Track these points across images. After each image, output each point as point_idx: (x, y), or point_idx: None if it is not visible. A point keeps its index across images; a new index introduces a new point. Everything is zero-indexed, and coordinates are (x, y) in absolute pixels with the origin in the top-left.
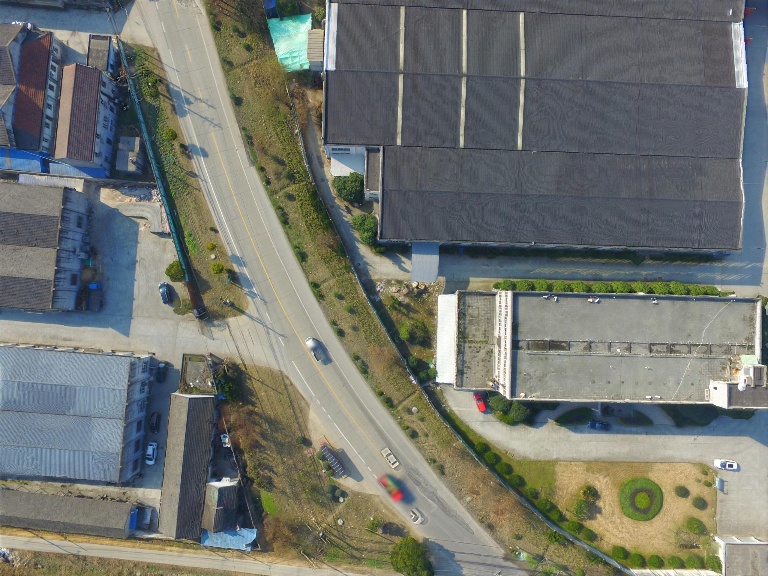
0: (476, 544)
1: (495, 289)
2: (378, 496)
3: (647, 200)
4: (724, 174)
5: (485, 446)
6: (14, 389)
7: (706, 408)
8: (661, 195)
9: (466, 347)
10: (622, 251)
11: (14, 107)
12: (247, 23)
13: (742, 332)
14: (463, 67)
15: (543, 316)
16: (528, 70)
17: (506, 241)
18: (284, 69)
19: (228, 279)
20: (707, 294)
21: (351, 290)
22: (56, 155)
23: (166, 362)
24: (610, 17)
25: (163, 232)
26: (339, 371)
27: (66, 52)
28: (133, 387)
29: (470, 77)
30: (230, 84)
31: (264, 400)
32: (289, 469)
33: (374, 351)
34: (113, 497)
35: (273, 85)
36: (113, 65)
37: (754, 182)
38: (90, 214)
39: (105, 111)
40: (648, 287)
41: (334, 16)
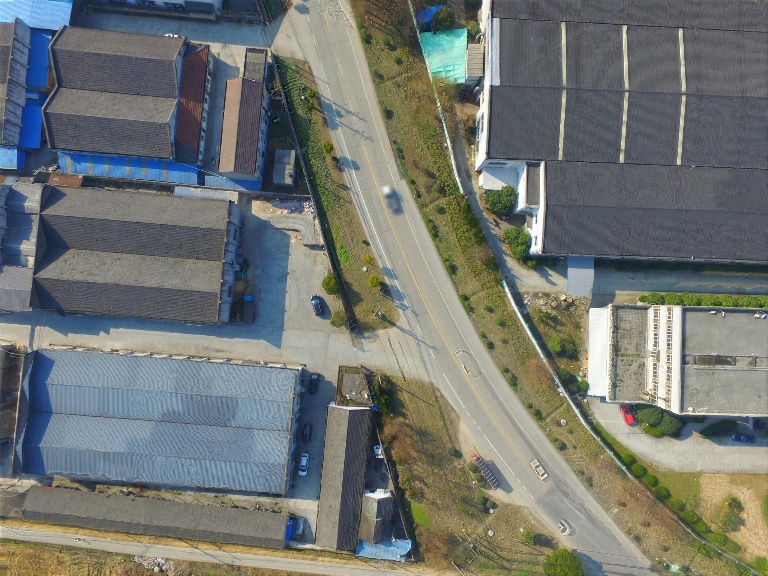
0: (623, 555)
1: (640, 302)
2: (527, 507)
3: None
4: None
5: (631, 458)
6: (172, 400)
7: None
8: None
9: (618, 360)
10: (767, 265)
11: (176, 120)
12: (398, 36)
13: None
14: (625, 83)
15: (710, 331)
16: (689, 86)
17: (666, 256)
18: (437, 83)
19: (381, 292)
20: None
21: (500, 303)
22: (220, 168)
23: (318, 374)
24: (767, 33)
25: (316, 244)
26: (489, 383)
27: (217, 64)
28: (295, 399)
29: (632, 93)
30: (381, 97)
31: (415, 412)
32: (439, 480)
33: (523, 363)
34: (266, 508)
35: (423, 98)
36: (266, 78)
37: None
38: (242, 226)
39: (263, 124)
40: None
41: (496, 31)
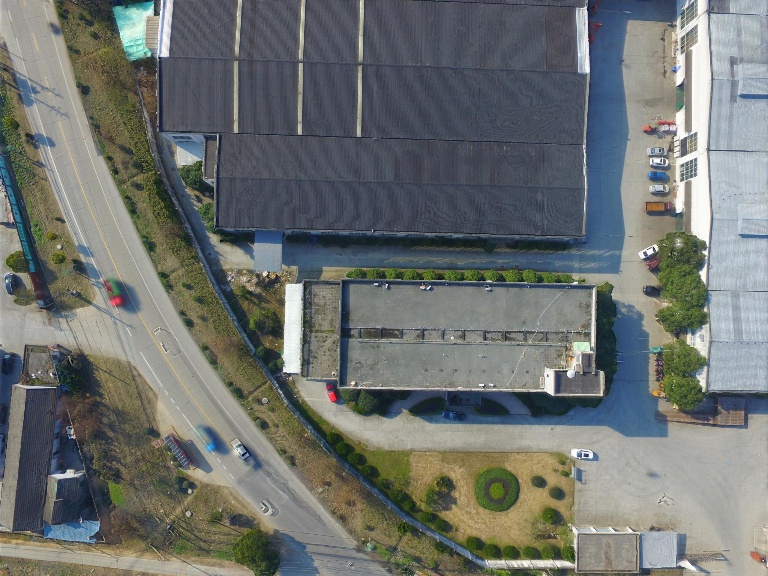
0: (328, 535)
1: None
2: (227, 487)
3: (487, 187)
4: (569, 160)
5: (337, 437)
6: None
7: (557, 397)
8: (502, 182)
9: (312, 336)
10: (476, 239)
11: None
12: (95, 11)
13: (578, 319)
14: (300, 53)
15: (375, 304)
16: (366, 56)
17: (345, 229)
18: (129, 57)
19: (73, 269)
20: (558, 282)
21: (200, 280)
22: None
23: (12, 353)
24: (452, 3)
25: (8, 222)
26: (188, 362)
27: None
28: None
29: (306, 63)
30: (77, 73)
31: (111, 391)
32: (137, 461)
33: (223, 341)
34: None
35: (121, 74)
36: None
37: (613, 169)
38: None
39: None
40: (497, 275)
41: (170, 3)
